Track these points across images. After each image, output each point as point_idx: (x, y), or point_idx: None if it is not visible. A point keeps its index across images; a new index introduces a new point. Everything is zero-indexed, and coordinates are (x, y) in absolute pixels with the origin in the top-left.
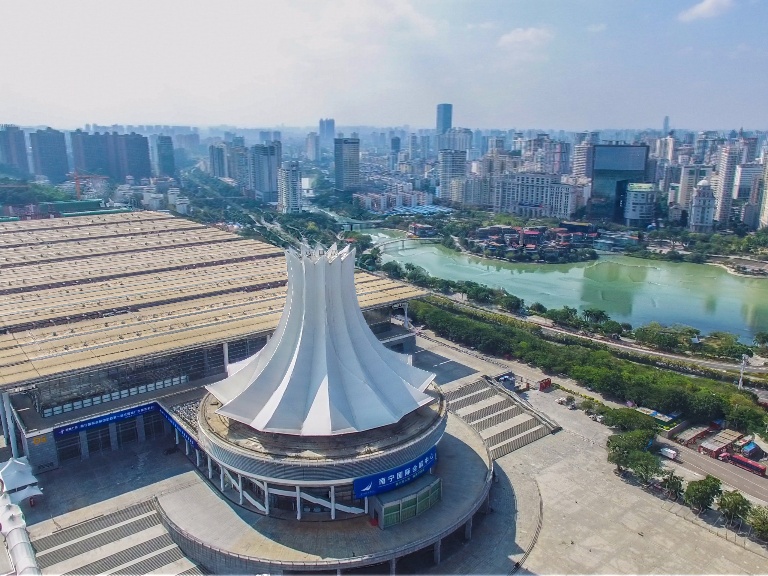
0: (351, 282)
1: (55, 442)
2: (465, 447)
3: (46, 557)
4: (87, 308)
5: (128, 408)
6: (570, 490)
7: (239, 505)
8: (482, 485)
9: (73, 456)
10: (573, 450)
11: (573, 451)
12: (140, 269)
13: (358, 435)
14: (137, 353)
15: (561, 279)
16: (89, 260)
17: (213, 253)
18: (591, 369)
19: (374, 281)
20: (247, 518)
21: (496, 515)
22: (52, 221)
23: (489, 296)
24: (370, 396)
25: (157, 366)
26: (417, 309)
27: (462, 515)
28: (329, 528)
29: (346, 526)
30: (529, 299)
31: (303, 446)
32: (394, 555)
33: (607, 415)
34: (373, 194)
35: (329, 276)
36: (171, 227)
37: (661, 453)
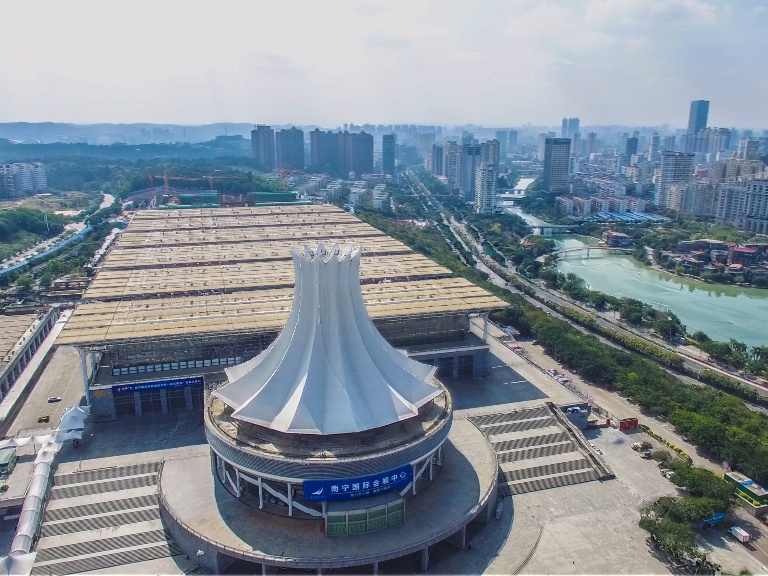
0: (355, 284)
1: (113, 397)
2: (471, 474)
3: (58, 491)
4: (193, 287)
5: (178, 378)
6: (576, 547)
7: (222, 483)
8: (458, 517)
9: (131, 412)
10: (612, 504)
11: (611, 505)
12: (267, 256)
13: (324, 438)
14: (190, 330)
15: (760, 307)
16: (234, 245)
17: (341, 247)
18: (694, 416)
19: (464, 287)
20: (220, 496)
21: (471, 553)
22: (241, 209)
23: (648, 318)
24: (344, 401)
25: (213, 344)
26: (534, 322)
27: (413, 543)
28: (280, 523)
29: (296, 525)
30: (703, 326)
31: (269, 438)
32: (320, 565)
33: (677, 472)
34: (578, 198)
35: (325, 276)
36: (330, 220)
37: (730, 532)
